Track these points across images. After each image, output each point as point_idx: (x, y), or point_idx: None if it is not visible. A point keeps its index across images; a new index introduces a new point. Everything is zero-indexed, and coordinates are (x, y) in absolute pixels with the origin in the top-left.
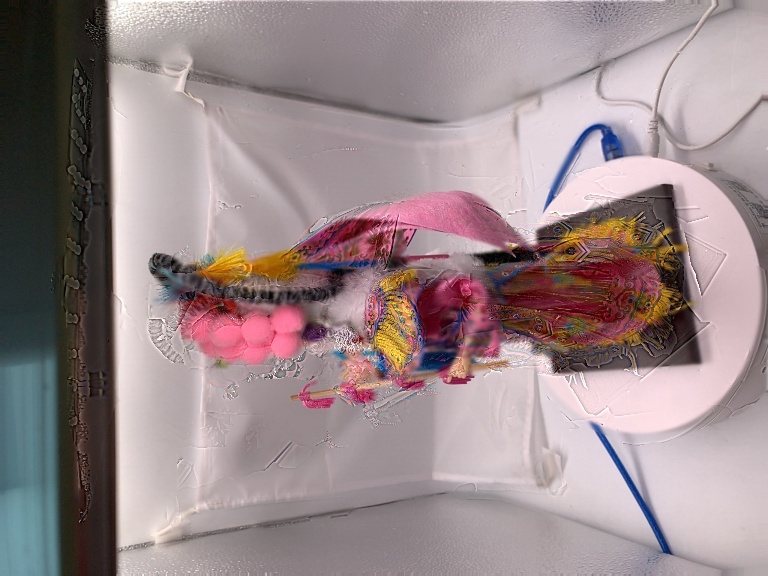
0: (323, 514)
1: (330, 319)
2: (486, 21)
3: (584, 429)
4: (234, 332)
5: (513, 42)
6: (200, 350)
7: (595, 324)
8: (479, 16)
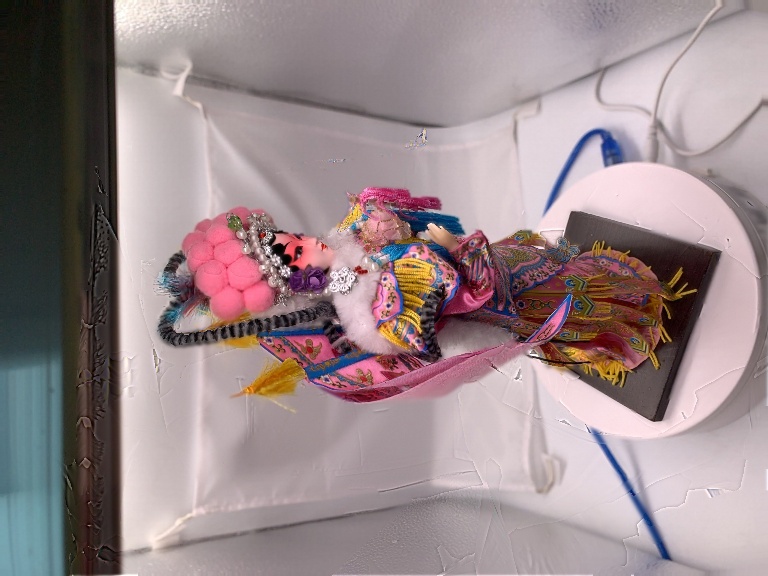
0: (767, 369)
1: None
2: (435, 510)
3: (753, 257)
4: None
5: (474, 510)
6: None
7: None
8: (427, 512)
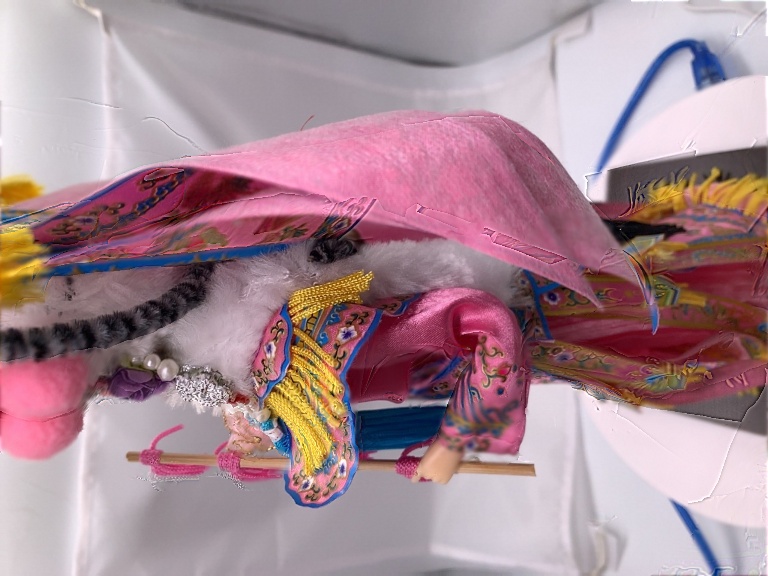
0: None
1: (180, 338)
2: None
3: None
4: None
5: None
6: None
7: None
8: None
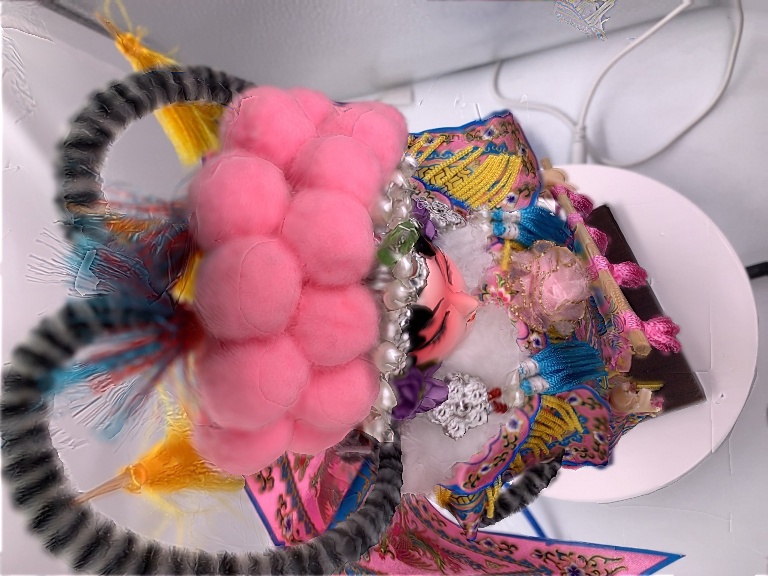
0: None
1: None
2: None
3: (727, 432)
4: None
5: None
6: (225, 157)
7: (560, 7)
8: None
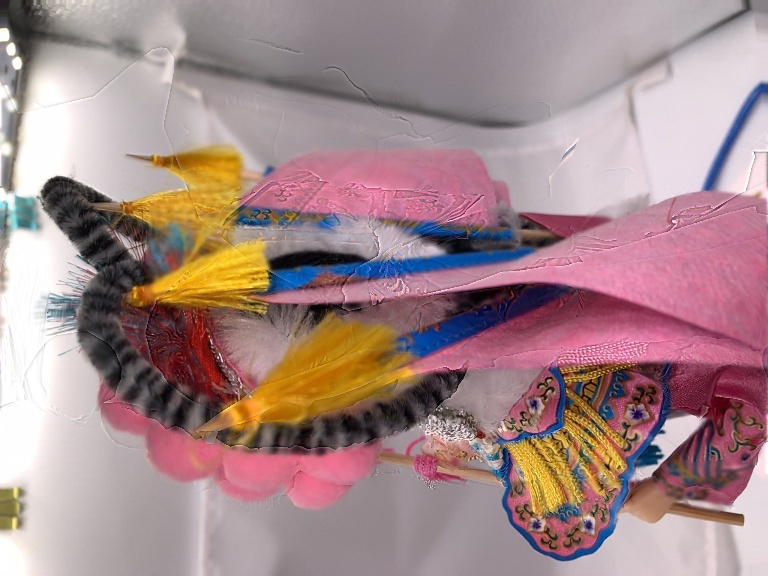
0: None
1: None
2: None
3: None
4: (204, 453)
5: None
6: (116, 440)
7: None
8: None
